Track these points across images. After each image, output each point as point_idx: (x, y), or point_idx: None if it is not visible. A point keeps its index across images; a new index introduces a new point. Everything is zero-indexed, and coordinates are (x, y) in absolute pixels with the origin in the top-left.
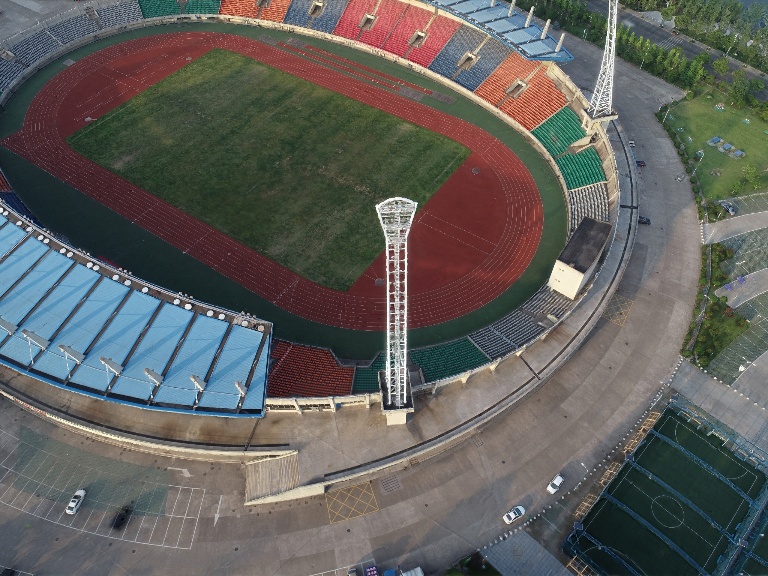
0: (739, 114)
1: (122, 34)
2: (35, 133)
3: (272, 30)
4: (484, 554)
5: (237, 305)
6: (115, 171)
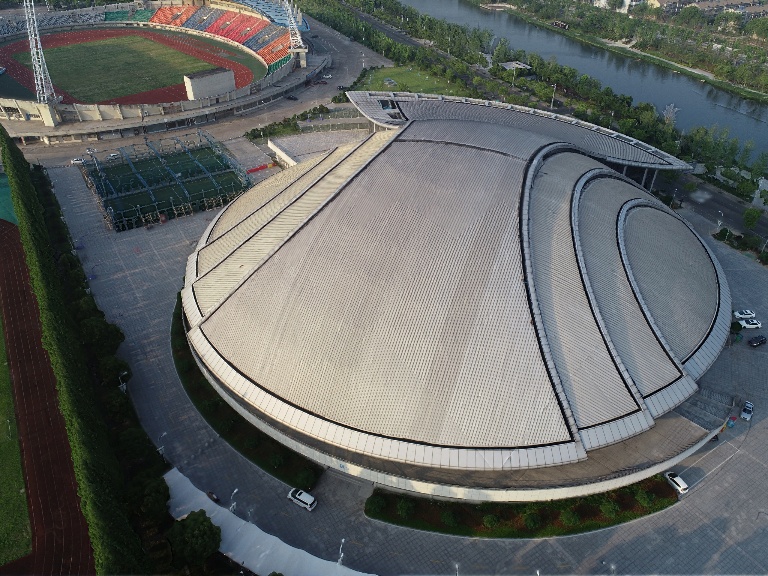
0: (419, 72)
1: (89, 28)
2: (0, 52)
3: None
4: (48, 169)
5: None
6: (24, 64)
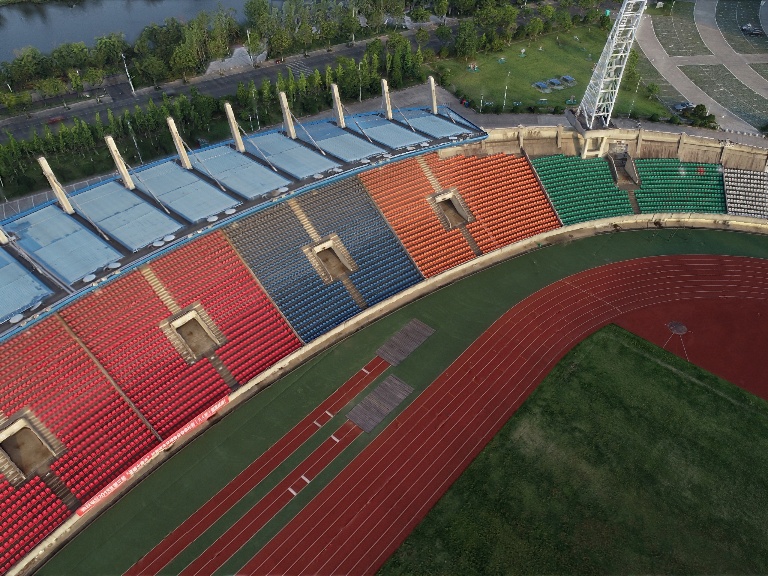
0: (486, 61)
1: None
2: None
3: None
4: None
5: None
6: None
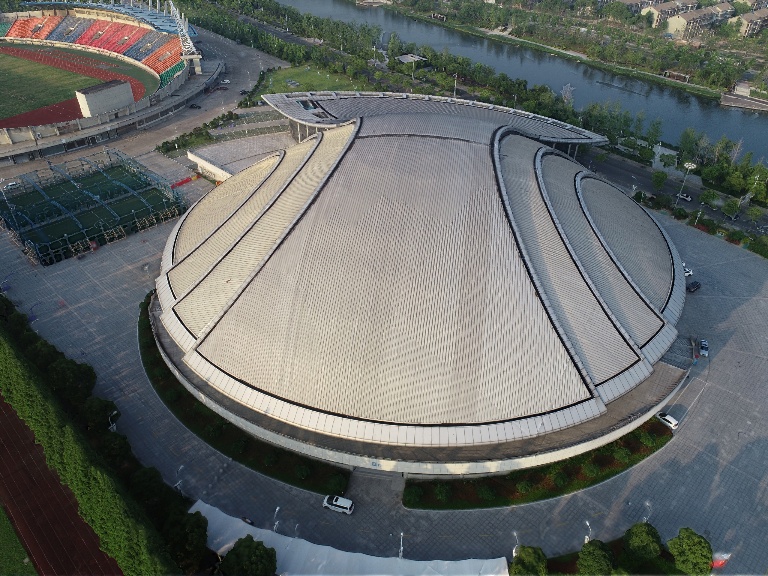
0: (318, 71)
1: None
2: None
3: (39, 45)
4: None
5: None
6: None
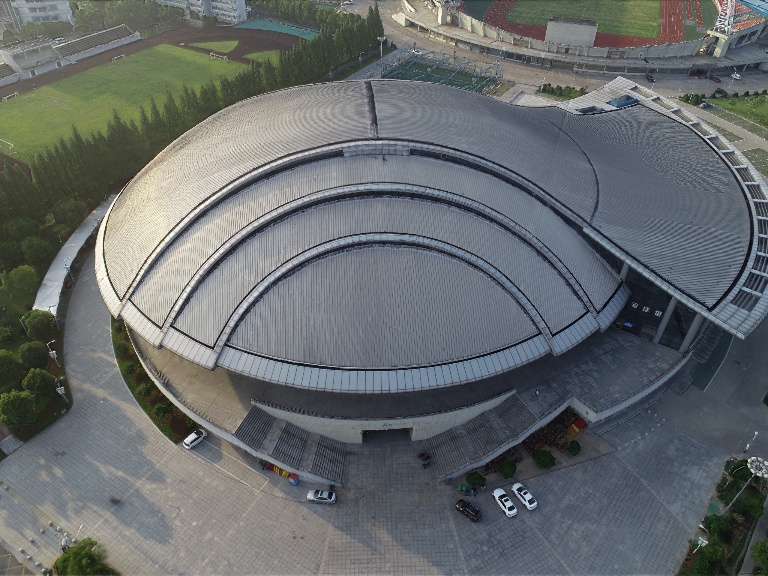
0: None
1: None
2: None
3: None
4: None
5: (479, 7)
6: None
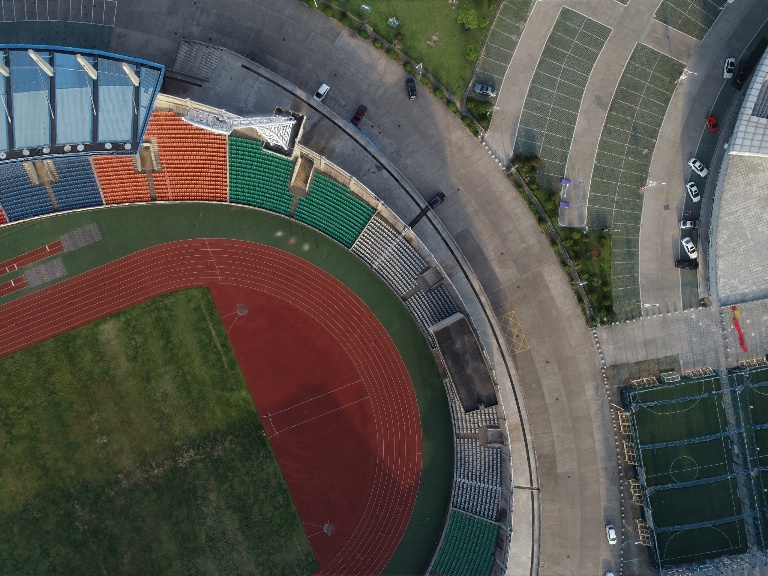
0: None
1: None
2: None
3: None
4: None
5: None
6: None
